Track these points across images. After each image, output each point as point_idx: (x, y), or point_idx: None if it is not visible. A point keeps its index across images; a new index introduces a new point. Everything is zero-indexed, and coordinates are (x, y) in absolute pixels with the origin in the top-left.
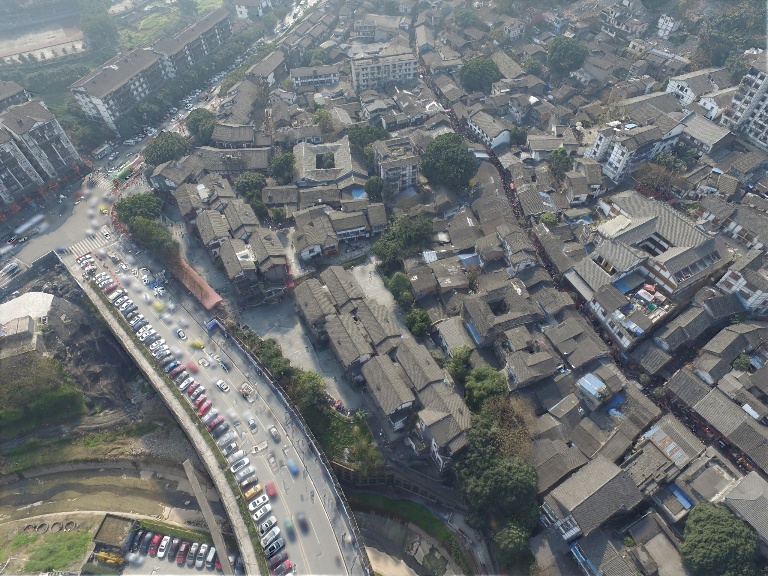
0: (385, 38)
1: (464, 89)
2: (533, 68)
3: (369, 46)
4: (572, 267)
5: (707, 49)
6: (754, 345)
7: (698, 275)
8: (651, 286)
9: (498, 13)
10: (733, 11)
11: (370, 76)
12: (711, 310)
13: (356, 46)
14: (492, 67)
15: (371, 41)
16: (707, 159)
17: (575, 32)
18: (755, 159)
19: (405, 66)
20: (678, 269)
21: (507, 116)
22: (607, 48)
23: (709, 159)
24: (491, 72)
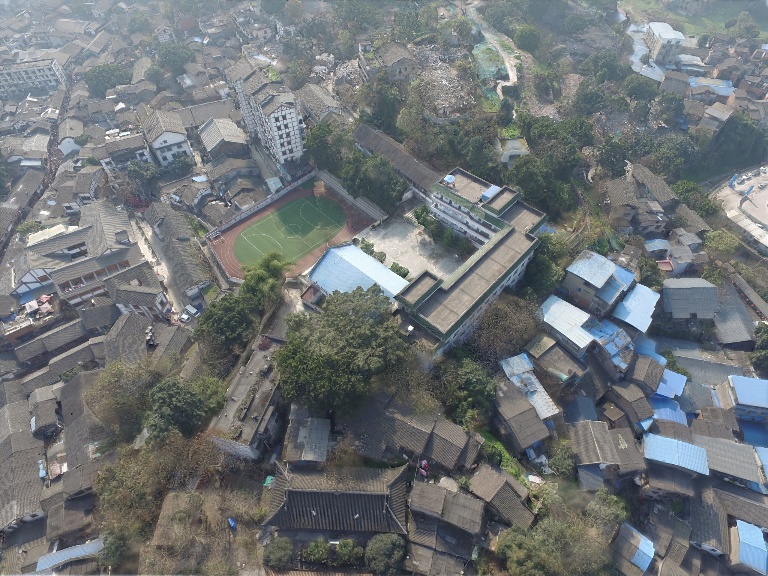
0: (62, 43)
1: (89, 95)
2: (149, 74)
3: (36, 52)
4: (1, 277)
5: (289, 55)
6: (98, 356)
7: (92, 285)
8: (45, 297)
9: (165, 18)
10: (316, 16)
11: (4, 83)
12: (84, 321)
13: (23, 52)
14: (112, 73)
15: (50, 46)
16: (209, 167)
17: (209, 37)
18: (228, 167)
19: (39, 72)
20: (66, 280)
21: (102, 123)
22: (227, 53)
23: (210, 167)
24: (109, 78)
